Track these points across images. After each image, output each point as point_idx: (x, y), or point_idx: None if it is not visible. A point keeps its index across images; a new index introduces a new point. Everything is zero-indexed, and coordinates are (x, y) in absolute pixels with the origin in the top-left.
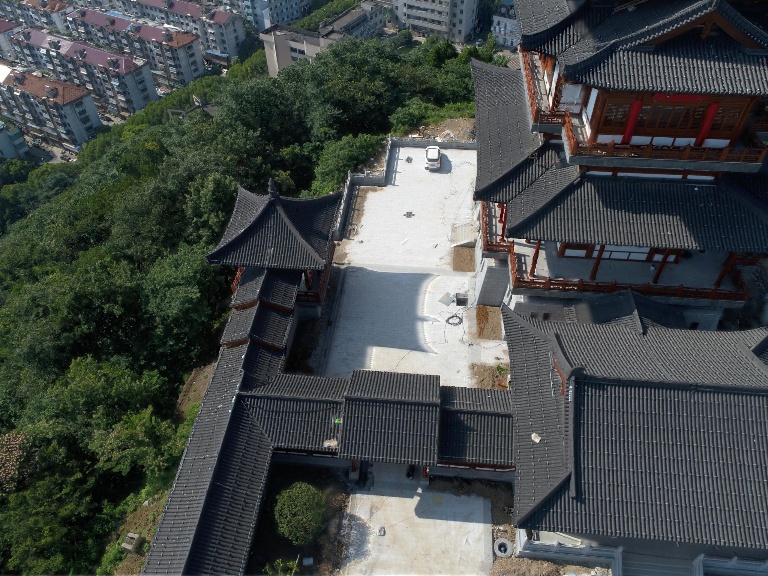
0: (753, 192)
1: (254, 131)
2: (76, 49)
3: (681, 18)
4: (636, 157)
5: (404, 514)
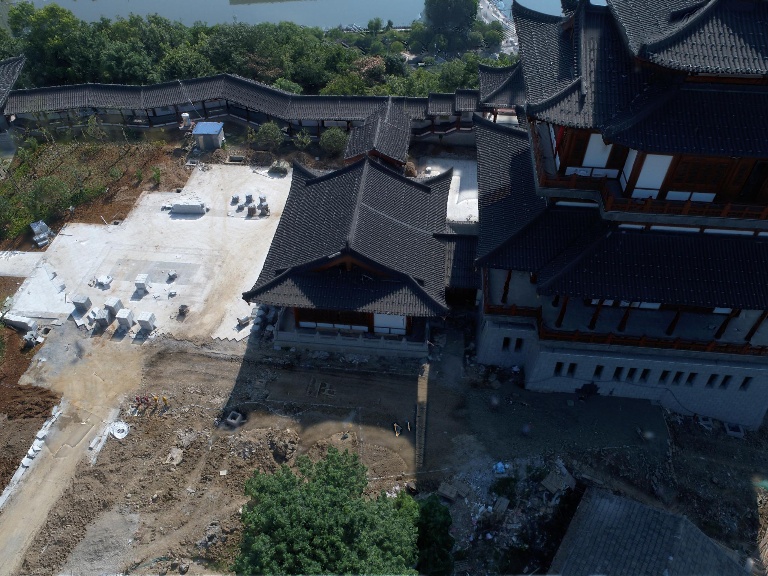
0: (565, 251)
1: None
2: None
3: None
4: None
5: None
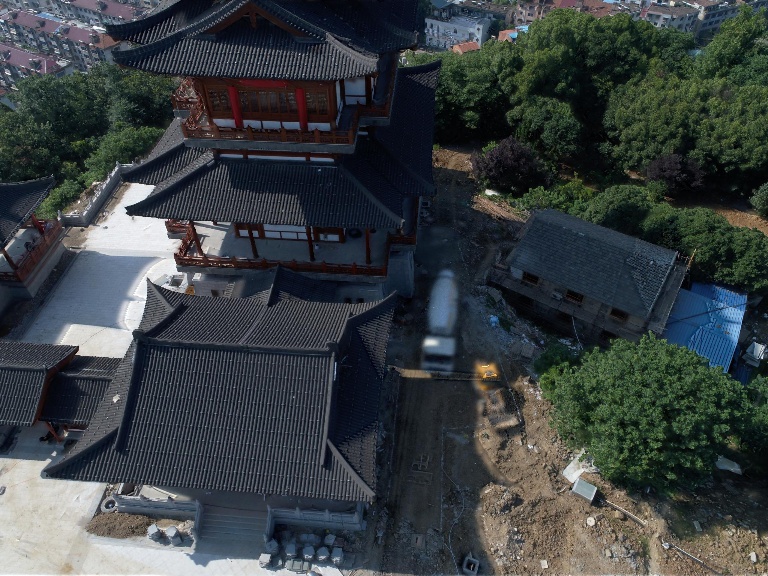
0: (383, 174)
1: (50, 124)
2: (0, 50)
3: (227, 9)
4: (242, 139)
5: (30, 475)
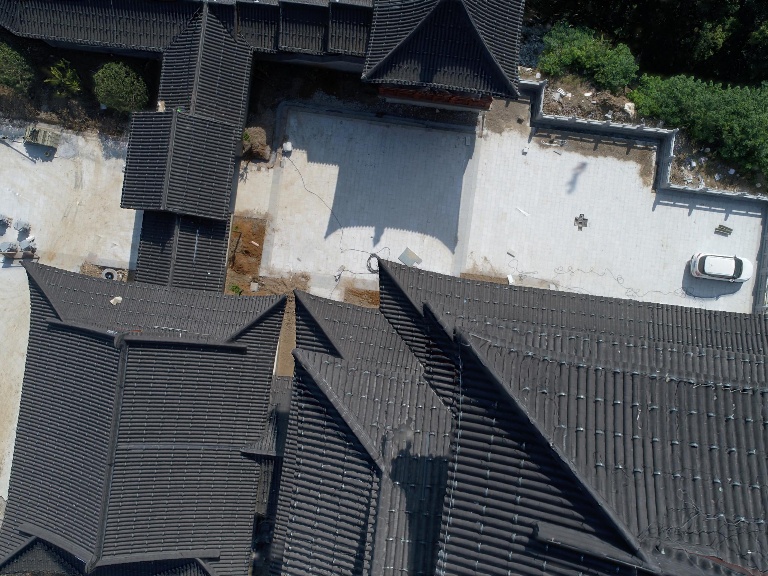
0: None
1: None
2: None
3: None
4: None
5: None
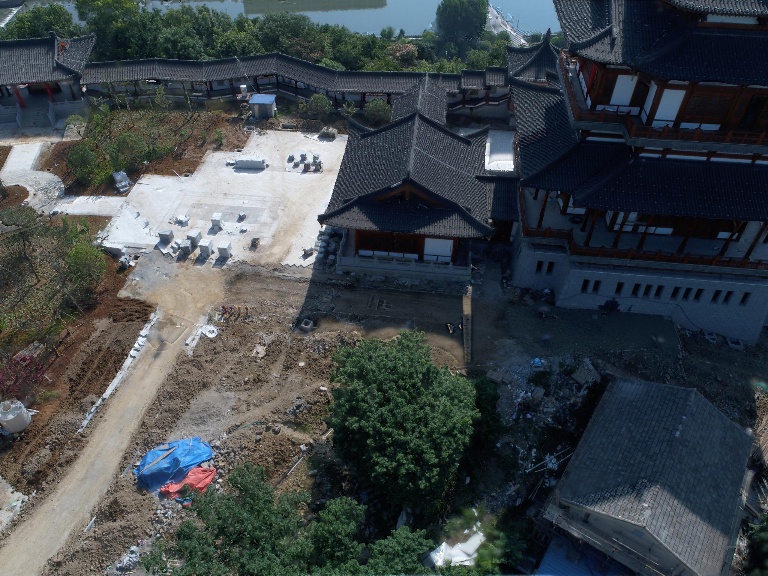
0: (594, 176)
1: None
2: None
3: None
4: None
5: None
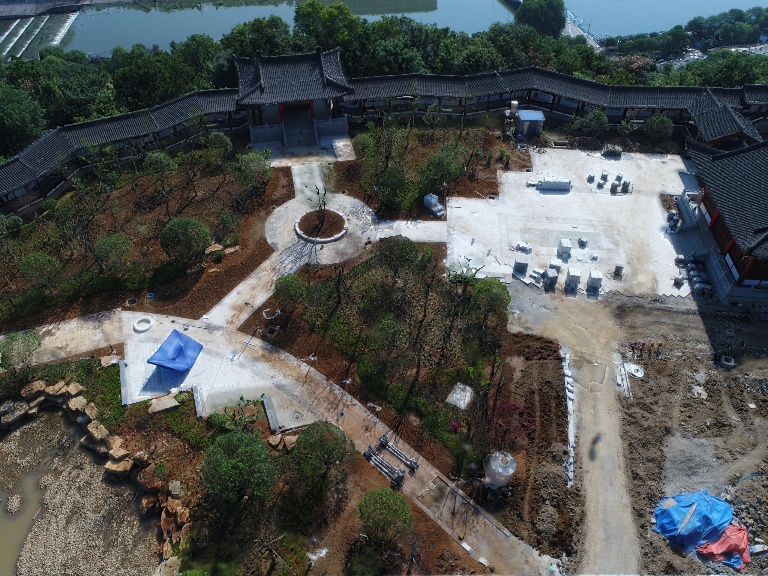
0: None
1: None
2: None
3: None
4: None
5: (677, 169)
